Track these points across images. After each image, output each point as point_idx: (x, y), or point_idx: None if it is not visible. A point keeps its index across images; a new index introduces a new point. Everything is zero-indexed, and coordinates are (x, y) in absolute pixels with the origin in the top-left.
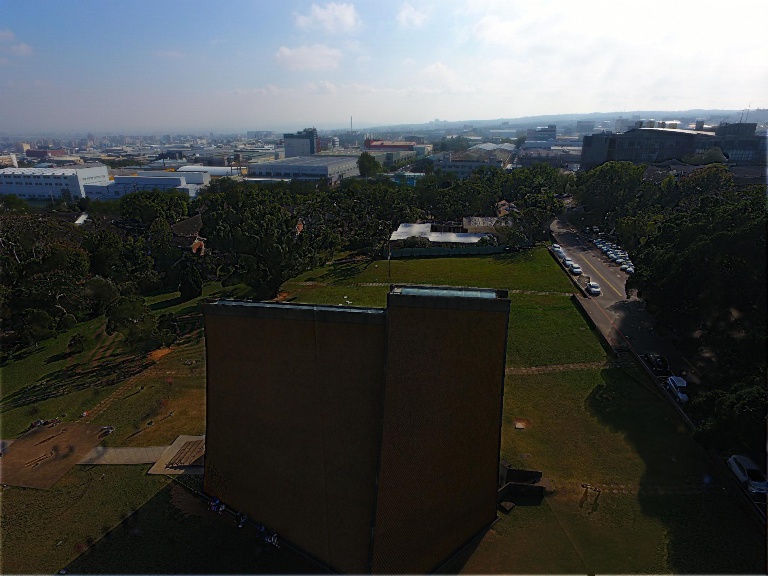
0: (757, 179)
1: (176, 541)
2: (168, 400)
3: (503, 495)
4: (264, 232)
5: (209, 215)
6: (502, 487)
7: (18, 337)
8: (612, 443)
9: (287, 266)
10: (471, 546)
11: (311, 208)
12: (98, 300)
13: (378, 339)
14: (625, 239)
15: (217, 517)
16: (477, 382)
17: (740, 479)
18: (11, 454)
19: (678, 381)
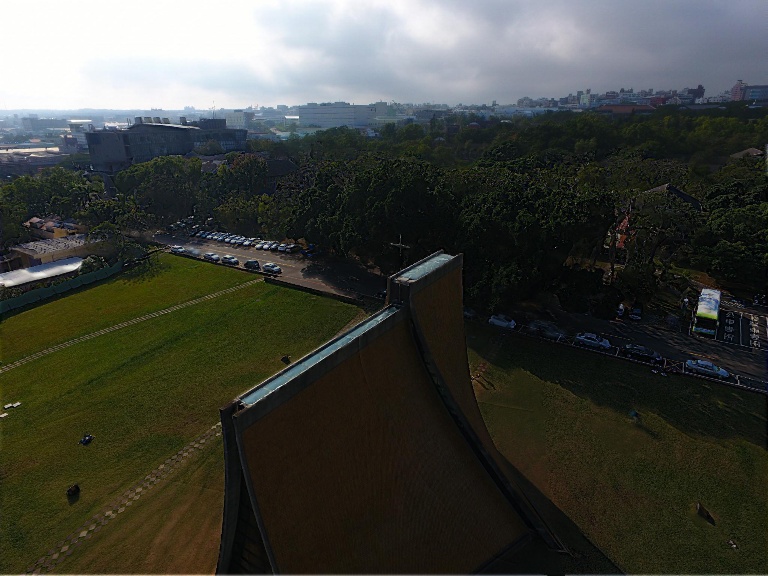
0: (272, 161)
1: None
2: None
3: None
4: None
5: None
6: None
7: None
8: None
9: None
10: None
11: None
12: None
13: (403, 336)
14: (230, 225)
15: None
16: None
17: (503, 326)
18: None
19: None
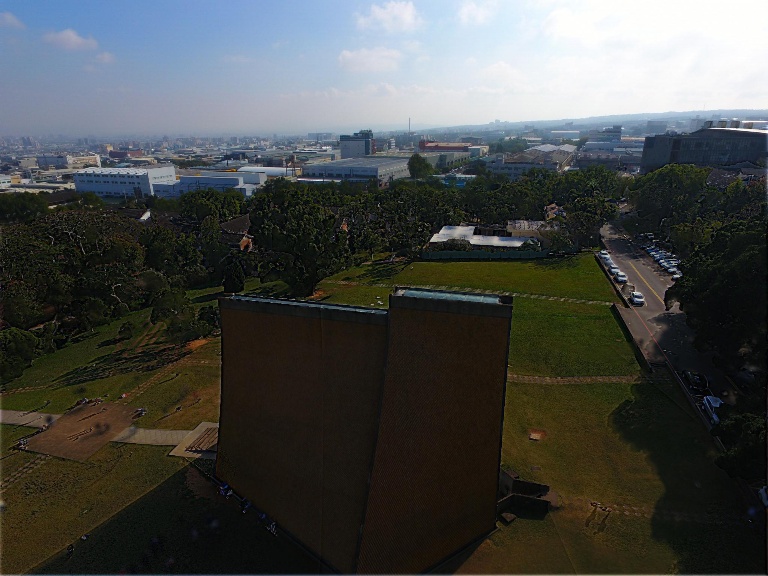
0: None
1: (184, 520)
2: (198, 388)
3: (505, 506)
4: (302, 231)
5: (255, 214)
6: (504, 497)
7: (79, 322)
8: (631, 462)
9: (323, 265)
10: (464, 554)
11: (354, 209)
12: (150, 291)
13: (381, 339)
14: (681, 247)
15: (224, 501)
16: (477, 388)
17: None
18: (57, 427)
19: (714, 401)
